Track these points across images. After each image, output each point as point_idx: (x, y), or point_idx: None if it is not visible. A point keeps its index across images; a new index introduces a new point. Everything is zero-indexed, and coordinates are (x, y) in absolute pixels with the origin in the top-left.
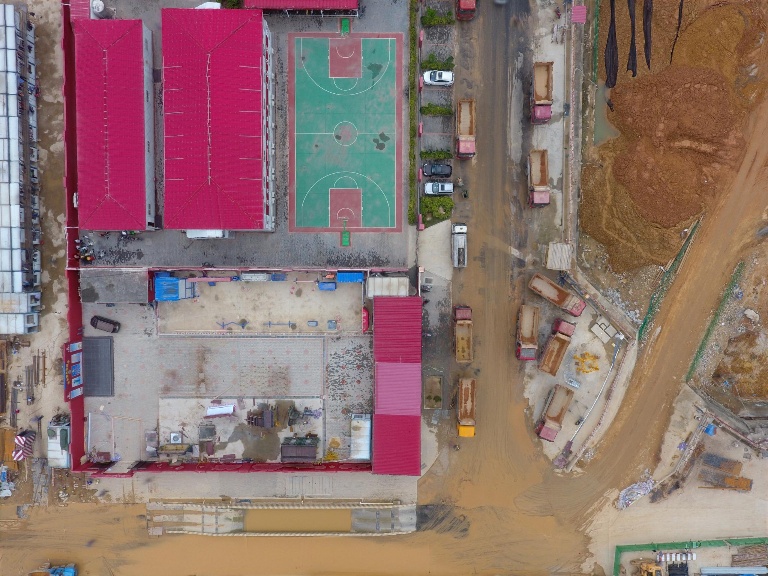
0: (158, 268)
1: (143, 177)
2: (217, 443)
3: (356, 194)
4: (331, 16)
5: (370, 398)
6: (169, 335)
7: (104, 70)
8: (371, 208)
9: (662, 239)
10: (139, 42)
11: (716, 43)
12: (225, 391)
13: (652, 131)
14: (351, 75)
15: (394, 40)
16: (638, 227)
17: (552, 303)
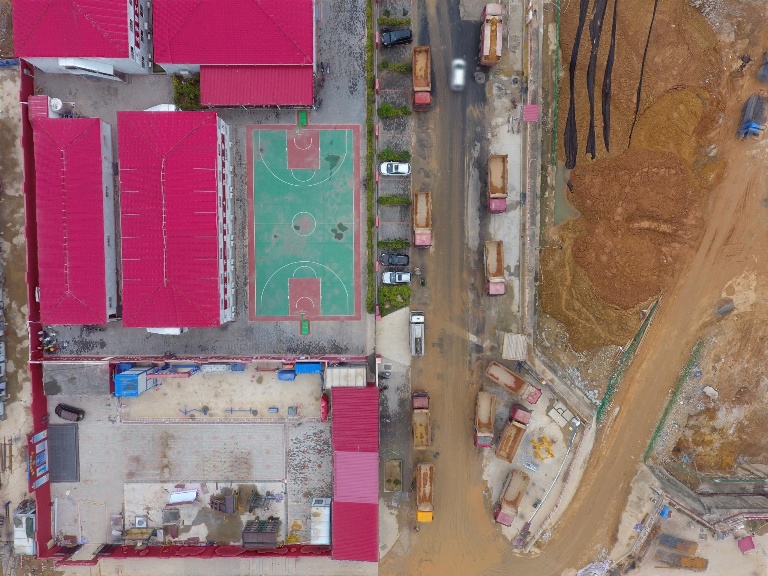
0: (119, 361)
1: (103, 273)
2: (181, 526)
3: (315, 283)
4: (288, 108)
5: None
6: (133, 422)
7: (62, 170)
8: (330, 297)
9: (620, 321)
10: (97, 140)
11: (674, 127)
12: (188, 476)
13: (610, 214)
14: (309, 166)
15: (351, 131)
16: (597, 308)
17: None
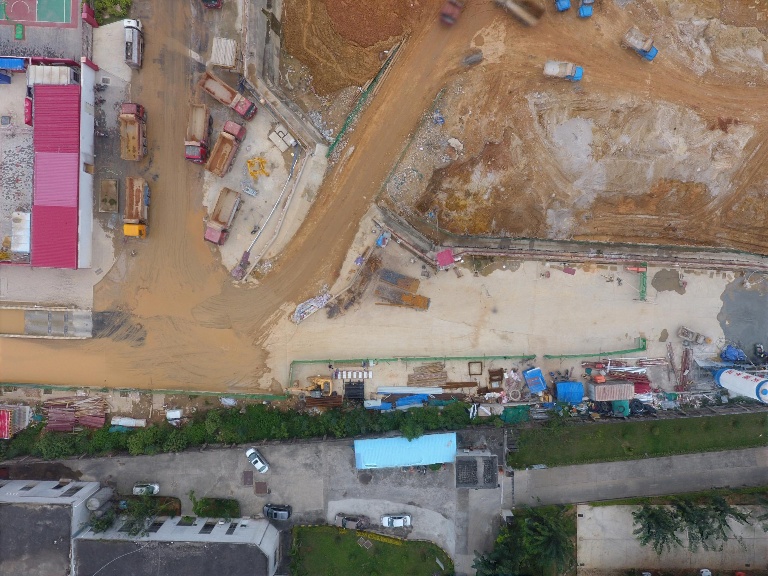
0: None
1: None
2: None
3: None
4: None
5: None
6: None
7: None
8: (46, 2)
9: (358, 57)
10: None
11: None
12: None
13: None
14: None
15: None
16: (336, 45)
17: None
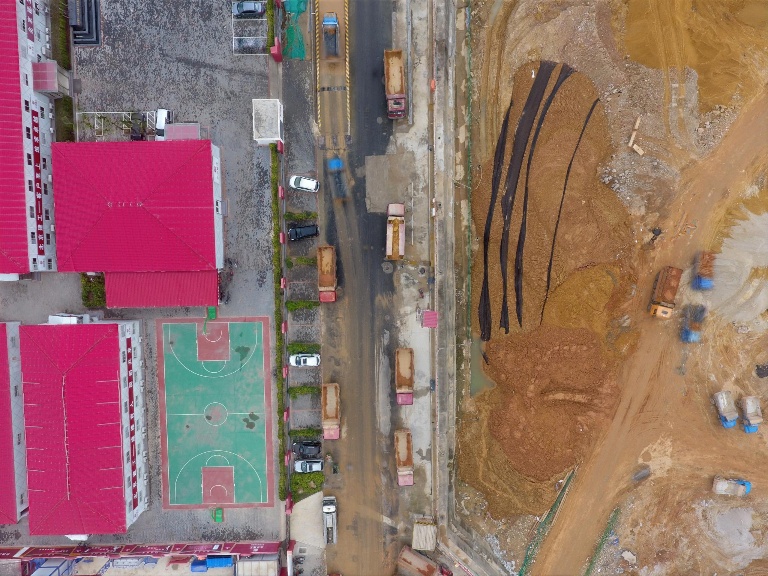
0: (31, 558)
1: (12, 474)
2: None
3: (228, 471)
4: None
5: None
6: None
7: None
8: (243, 485)
9: (536, 493)
10: (3, 345)
11: (584, 305)
12: None
13: (523, 391)
14: (219, 358)
15: (260, 323)
16: (513, 481)
17: None
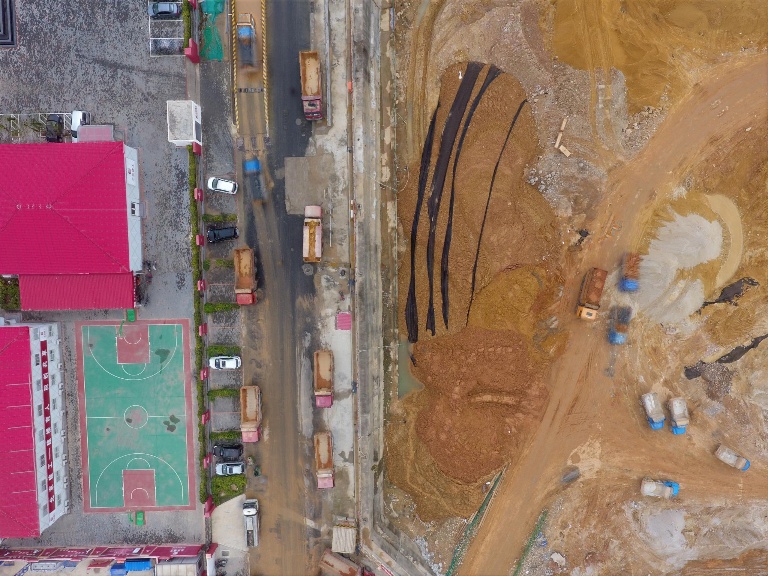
0: None
1: None
2: None
3: (149, 474)
4: None
5: None
6: None
7: None
8: (164, 488)
9: (463, 496)
10: None
11: (509, 307)
12: None
13: (449, 392)
14: (139, 360)
15: (180, 326)
16: (440, 483)
17: None
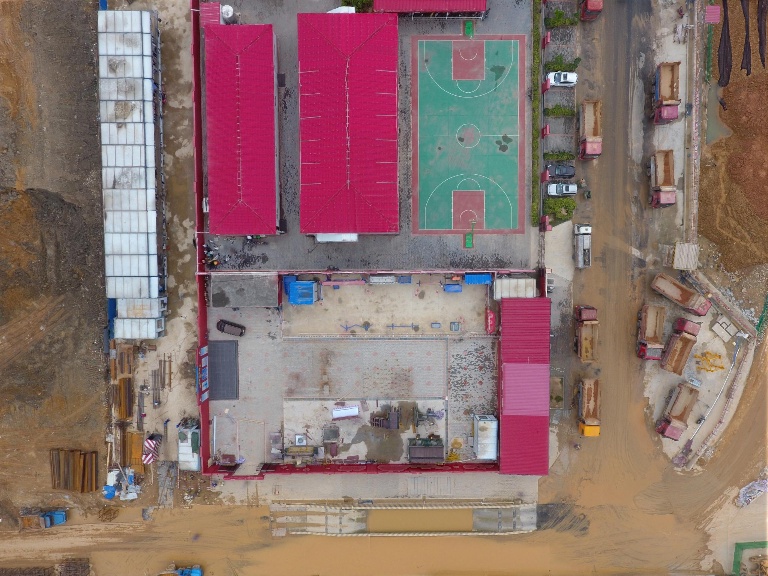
0: (287, 272)
1: (273, 182)
2: (341, 445)
3: (479, 196)
4: (454, 18)
5: (492, 399)
6: (293, 338)
7: (237, 75)
8: (494, 210)
9: None
10: (269, 47)
11: None
12: (348, 393)
13: None
14: (474, 77)
15: (517, 42)
16: (753, 226)
17: (673, 303)
